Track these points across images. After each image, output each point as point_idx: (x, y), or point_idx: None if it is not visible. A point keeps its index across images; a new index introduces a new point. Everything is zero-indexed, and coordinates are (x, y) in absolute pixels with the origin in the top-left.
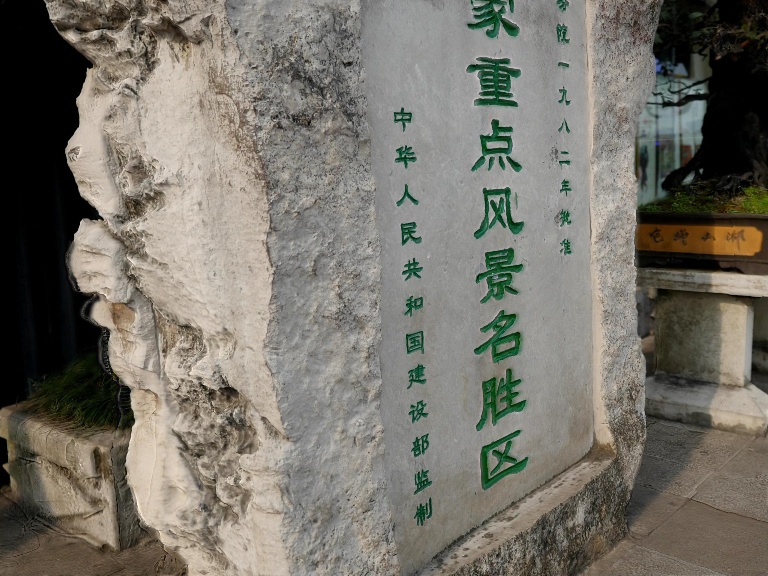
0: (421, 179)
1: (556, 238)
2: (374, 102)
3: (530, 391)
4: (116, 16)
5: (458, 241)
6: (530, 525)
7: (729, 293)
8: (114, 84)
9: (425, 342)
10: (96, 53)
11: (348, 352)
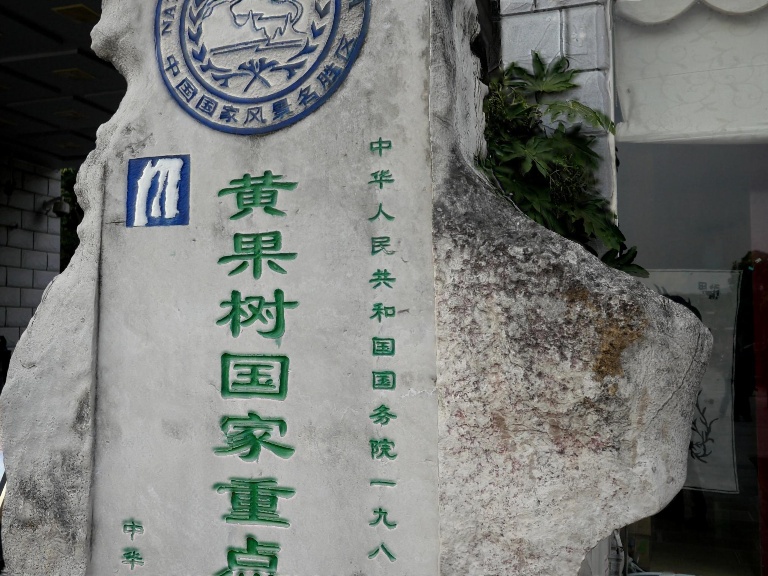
0: None
1: None
2: (107, 516)
3: None
4: None
5: None
6: None
7: None
8: None
9: None
10: None
11: None
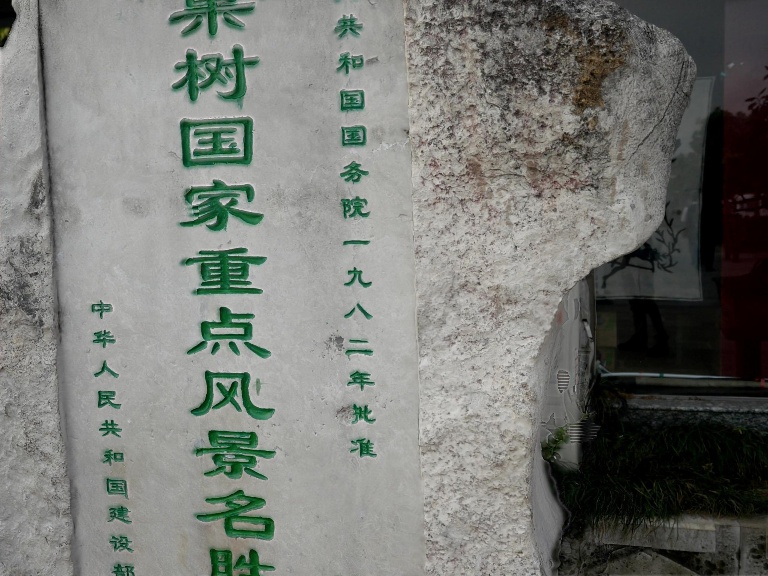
0: (123, 357)
1: (339, 435)
2: (74, 297)
3: None
4: None
5: (168, 414)
6: None
7: None
8: None
9: (130, 491)
10: None
11: (39, 475)
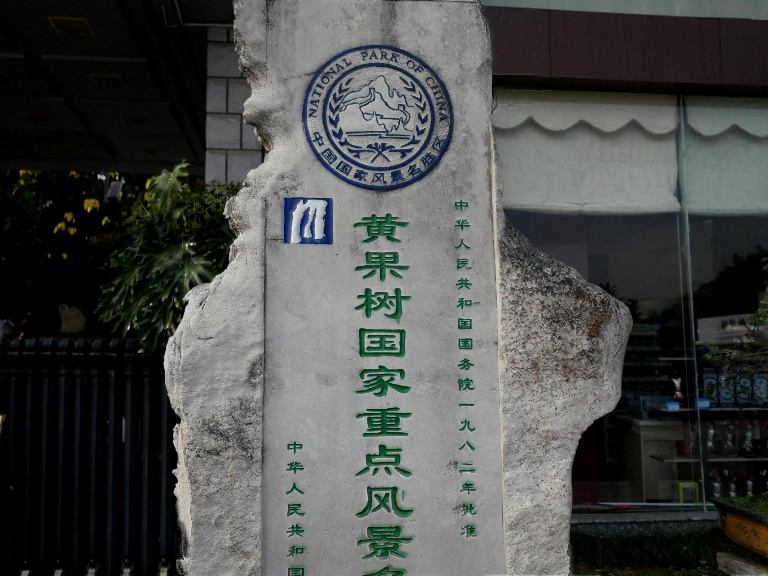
0: (308, 480)
1: (454, 524)
2: (274, 440)
3: None
4: None
5: (339, 518)
6: None
7: None
8: None
9: (305, 575)
10: None
11: (237, 570)
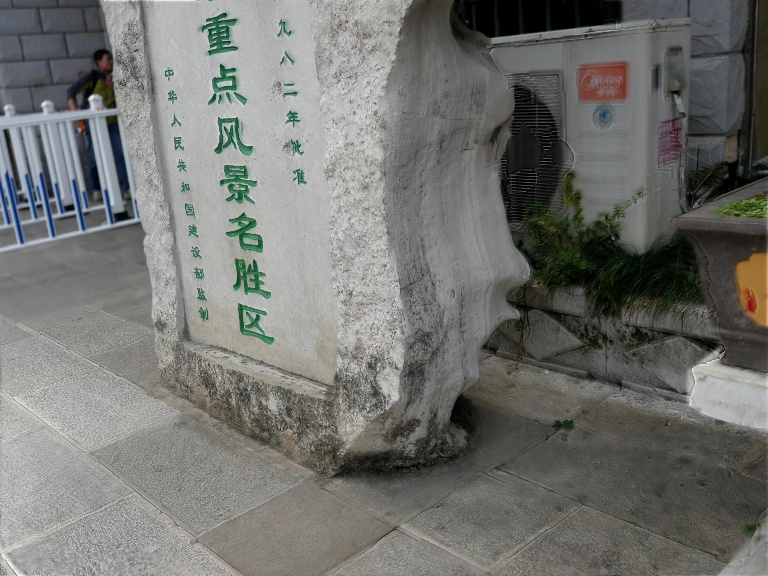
0: None
1: (285, 166)
2: None
3: (275, 288)
4: None
5: (204, 153)
6: (228, 367)
7: None
8: None
9: None
10: None
11: None
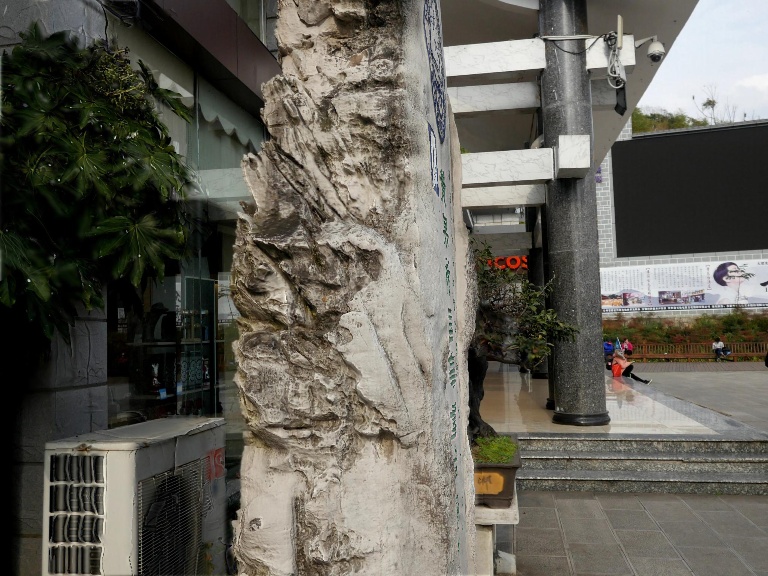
0: None
1: None
2: None
3: None
4: (318, 419)
5: None
6: None
7: (483, 524)
8: (303, 468)
9: None
10: (294, 445)
11: None
